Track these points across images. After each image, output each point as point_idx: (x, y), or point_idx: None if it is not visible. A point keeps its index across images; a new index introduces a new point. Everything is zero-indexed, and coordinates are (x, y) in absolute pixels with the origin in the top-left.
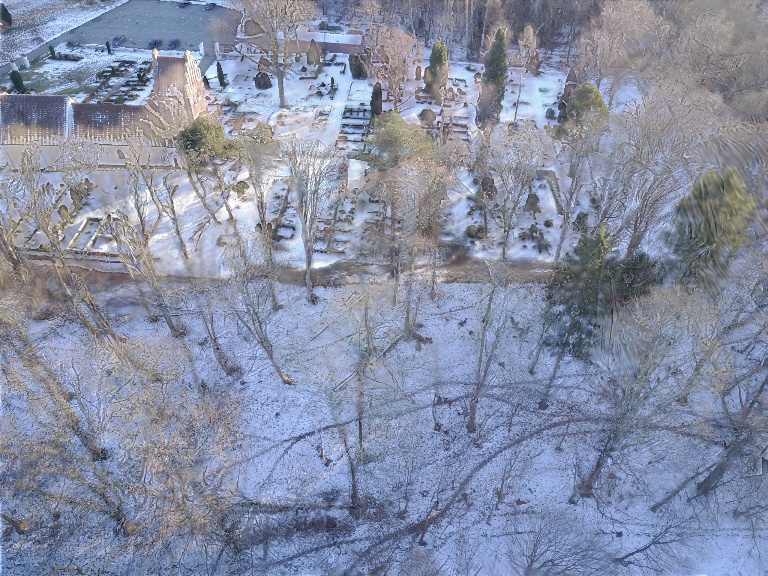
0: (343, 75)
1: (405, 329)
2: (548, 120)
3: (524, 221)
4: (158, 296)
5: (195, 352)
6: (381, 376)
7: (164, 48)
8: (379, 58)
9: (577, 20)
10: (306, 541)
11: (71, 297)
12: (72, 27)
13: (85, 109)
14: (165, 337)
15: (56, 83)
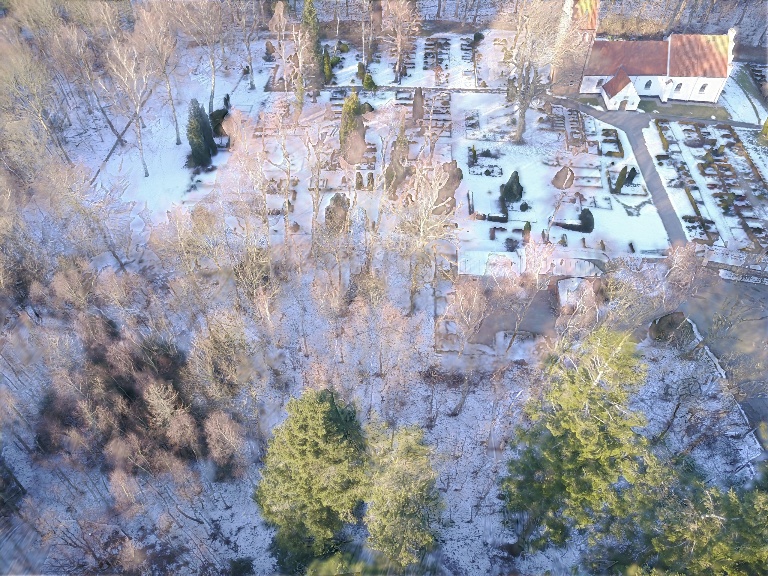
0: None
1: None
2: None
3: None
4: None
5: (489, 10)
6: None
7: None
8: None
9: None
10: None
11: None
12: None
13: None
14: None
15: None
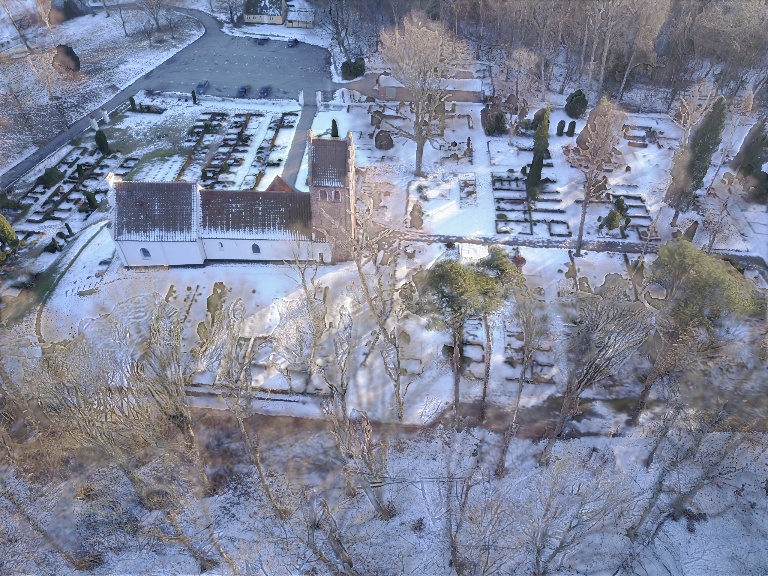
0: (473, 131)
1: (678, 507)
2: (726, 186)
3: None
4: (349, 457)
5: (412, 542)
6: (655, 573)
7: (255, 96)
8: (507, 108)
9: (730, 61)
10: None
11: (267, 486)
12: (146, 71)
13: (215, 197)
14: (371, 520)
15: (143, 142)
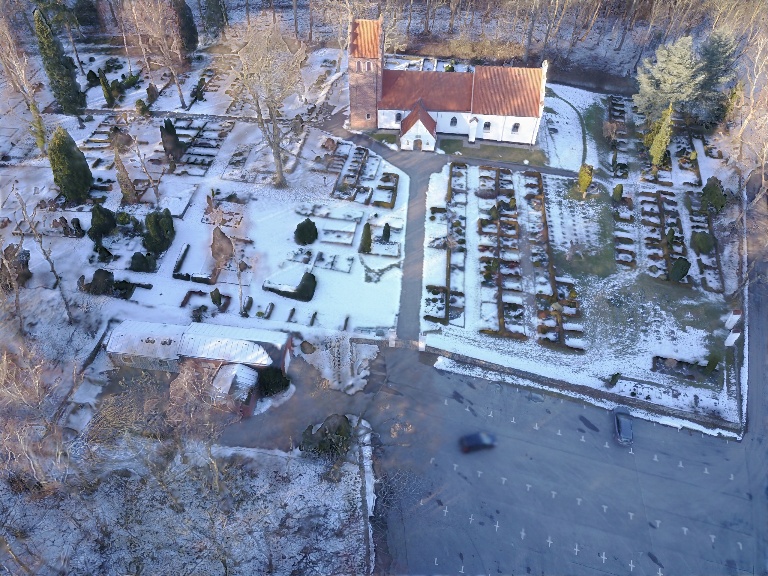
0: None
1: None
2: None
3: (109, 77)
4: None
5: None
6: None
7: (511, 391)
8: None
9: None
10: (291, 4)
11: None
12: None
13: None
14: None
15: (636, 293)
